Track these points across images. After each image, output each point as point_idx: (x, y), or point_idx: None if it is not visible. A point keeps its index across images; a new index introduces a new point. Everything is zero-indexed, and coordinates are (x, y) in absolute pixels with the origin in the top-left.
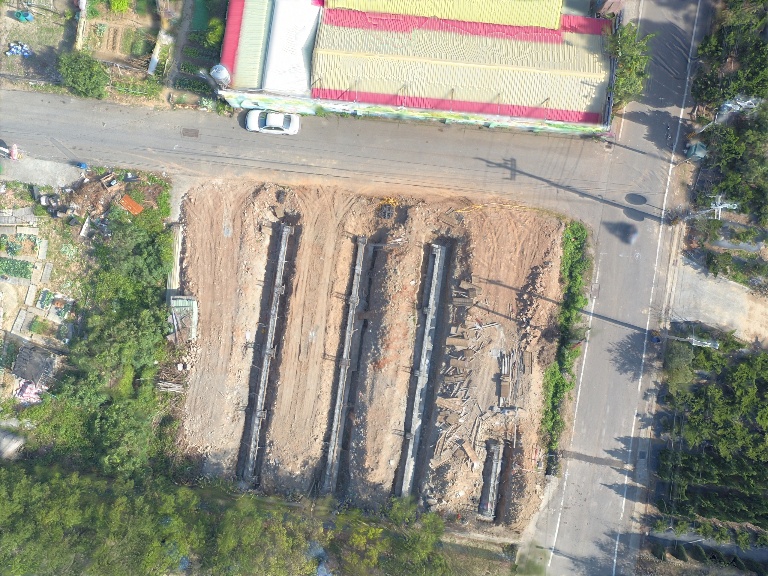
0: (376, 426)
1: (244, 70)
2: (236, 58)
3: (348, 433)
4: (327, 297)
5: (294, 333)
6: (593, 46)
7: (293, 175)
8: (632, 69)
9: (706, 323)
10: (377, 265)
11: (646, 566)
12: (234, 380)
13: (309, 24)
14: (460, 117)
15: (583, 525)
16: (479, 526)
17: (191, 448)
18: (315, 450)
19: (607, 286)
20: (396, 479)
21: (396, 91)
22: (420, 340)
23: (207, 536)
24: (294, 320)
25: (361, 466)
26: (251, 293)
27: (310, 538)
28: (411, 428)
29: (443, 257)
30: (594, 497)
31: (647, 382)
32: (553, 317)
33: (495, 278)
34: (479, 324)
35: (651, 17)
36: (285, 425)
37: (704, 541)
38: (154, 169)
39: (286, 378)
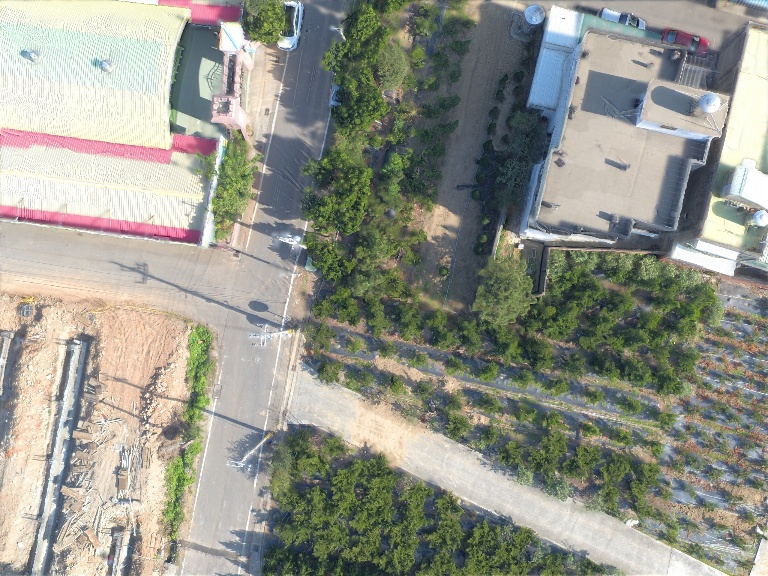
0: (5, 510)
1: None
2: None
3: None
4: None
5: None
6: (198, 167)
7: None
8: (235, 190)
9: (319, 427)
10: (16, 359)
11: None
12: None
13: None
14: None
15: None
16: None
17: None
18: None
19: (228, 388)
20: (31, 558)
21: (16, 204)
22: None
23: None
24: None
25: None
26: None
27: None
28: (43, 512)
29: (84, 352)
30: None
31: (263, 479)
32: (177, 414)
33: (121, 377)
34: (104, 419)
35: (282, 133)
36: None
37: None
38: None
39: None
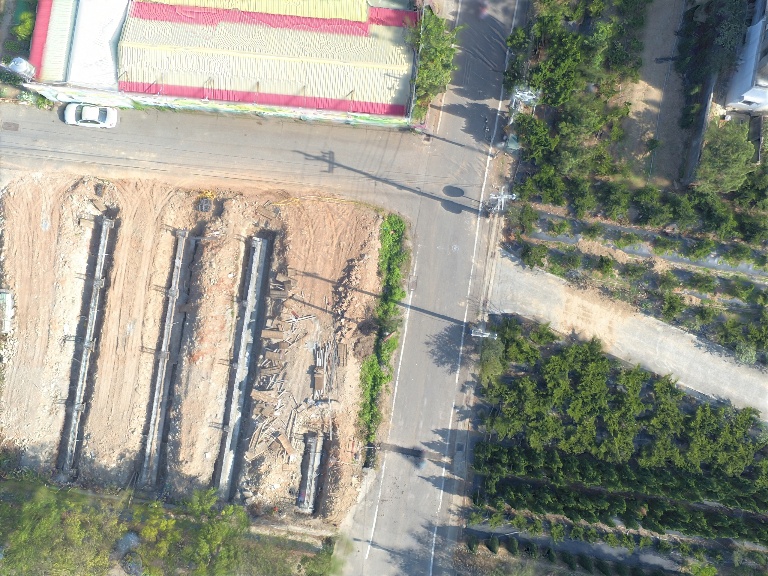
0: (191, 419)
1: (51, 63)
2: (44, 51)
3: (169, 426)
4: (145, 290)
5: (112, 326)
6: (398, 38)
7: (112, 168)
8: (438, 61)
9: (523, 315)
10: (195, 258)
11: (466, 559)
12: (51, 373)
13: (117, 17)
14: (268, 109)
15: (400, 517)
16: (296, 519)
17: (8, 441)
18: (133, 443)
19: (425, 278)
20: (216, 472)
21: (202, 84)
22: (240, 333)
23: (4, 528)
24: (112, 313)
25: (176, 459)
26: (70, 286)
27: (102, 530)
28: (229, 421)
29: (264, 250)
30: (411, 489)
31: (465, 374)
32: (371, 309)
33: (311, 271)
34: (295, 316)
35: (470, 10)
36: (102, 418)
37: (520, 533)
38: None
39: (104, 371)
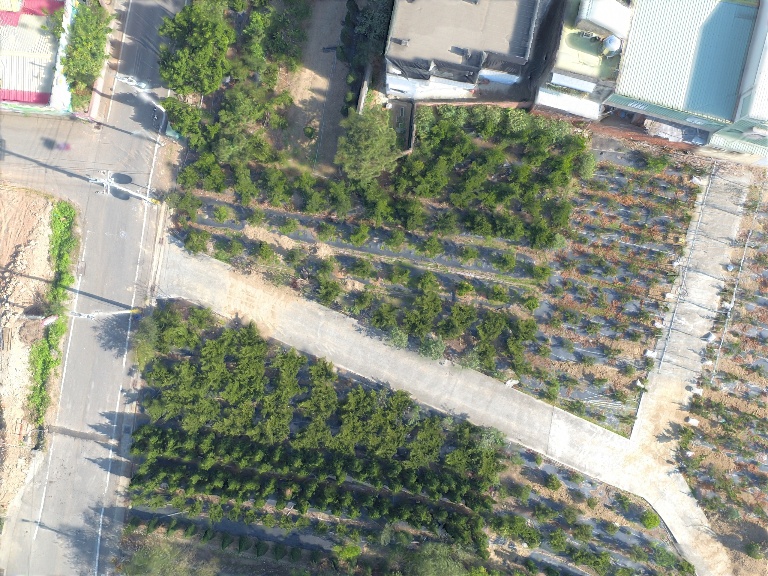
0: None
1: None
2: None
3: None
4: None
5: None
6: None
7: None
8: (86, 50)
9: (188, 300)
10: None
11: (135, 539)
12: None
13: None
14: None
15: (67, 499)
16: None
17: None
18: None
19: (93, 264)
20: None
21: None
22: None
23: None
24: None
25: None
26: None
27: None
28: None
29: None
30: (78, 471)
31: (132, 358)
32: (41, 294)
33: None
34: None
35: (141, 0)
36: None
37: (182, 514)
38: None
39: None
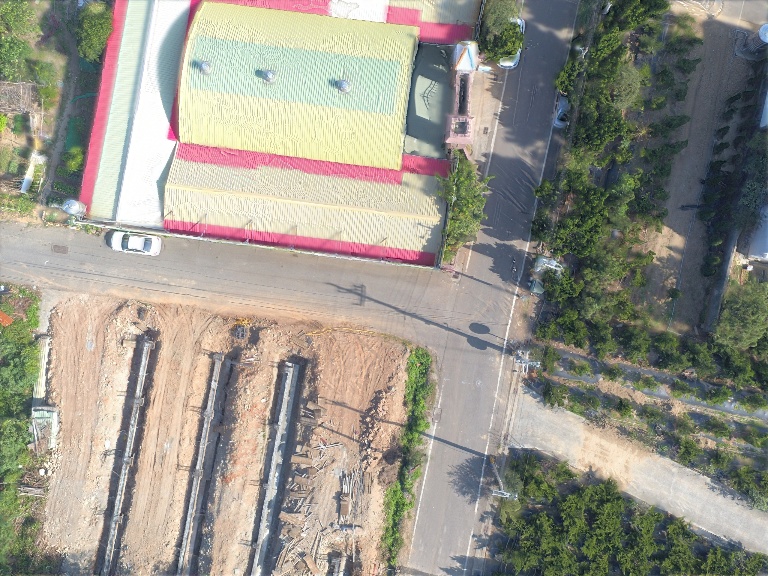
0: (222, 537)
1: (102, 201)
2: (96, 188)
3: (201, 538)
4: (182, 411)
5: (150, 444)
6: (432, 188)
7: (155, 293)
8: (469, 211)
9: (542, 451)
10: (230, 382)
11: None
12: (92, 486)
13: (165, 158)
14: None
15: None
16: None
17: (50, 548)
18: (166, 555)
19: (449, 411)
20: None
21: (243, 225)
22: (271, 454)
23: None
24: (151, 431)
25: (207, 574)
26: (112, 404)
27: None
28: (258, 538)
29: (296, 375)
30: None
31: (484, 504)
32: (396, 438)
33: (340, 400)
34: (323, 444)
35: (502, 152)
36: (138, 531)
37: None
38: (26, 283)
39: (141, 486)
